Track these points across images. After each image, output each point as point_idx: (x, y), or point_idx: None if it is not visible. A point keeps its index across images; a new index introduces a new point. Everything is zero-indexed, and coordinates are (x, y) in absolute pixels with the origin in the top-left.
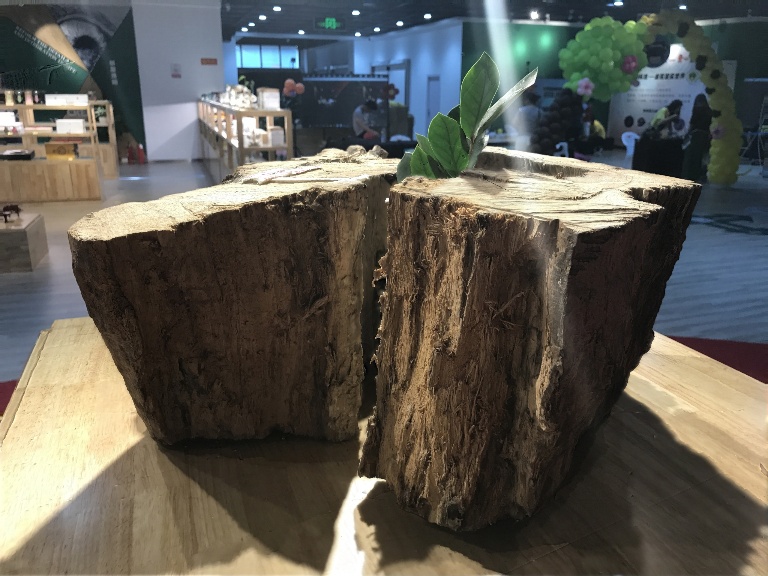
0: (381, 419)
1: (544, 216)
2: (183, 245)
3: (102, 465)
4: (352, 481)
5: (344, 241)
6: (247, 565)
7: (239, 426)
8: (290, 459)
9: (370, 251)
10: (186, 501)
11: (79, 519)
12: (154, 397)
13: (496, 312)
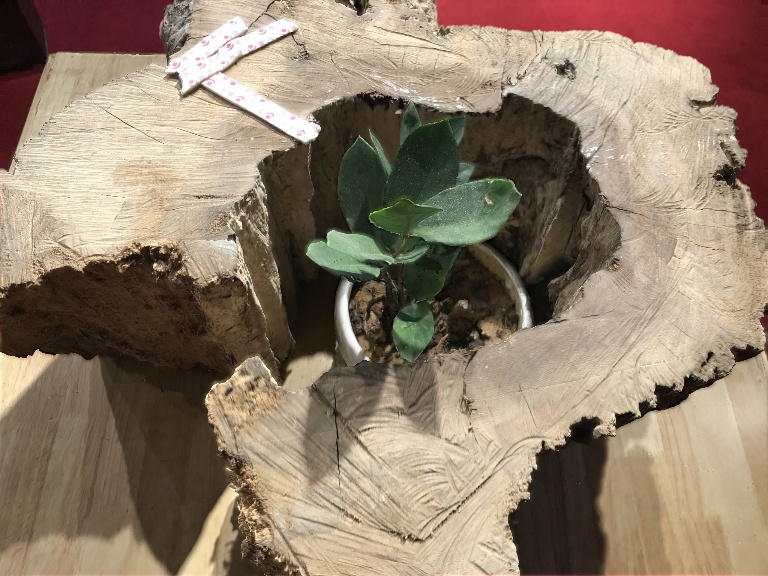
0: None
1: None
2: (25, 296)
3: (45, 361)
4: None
5: (218, 315)
6: (121, 546)
7: (160, 365)
8: None
9: None
10: (97, 444)
11: (12, 436)
12: (65, 348)
13: (292, 575)
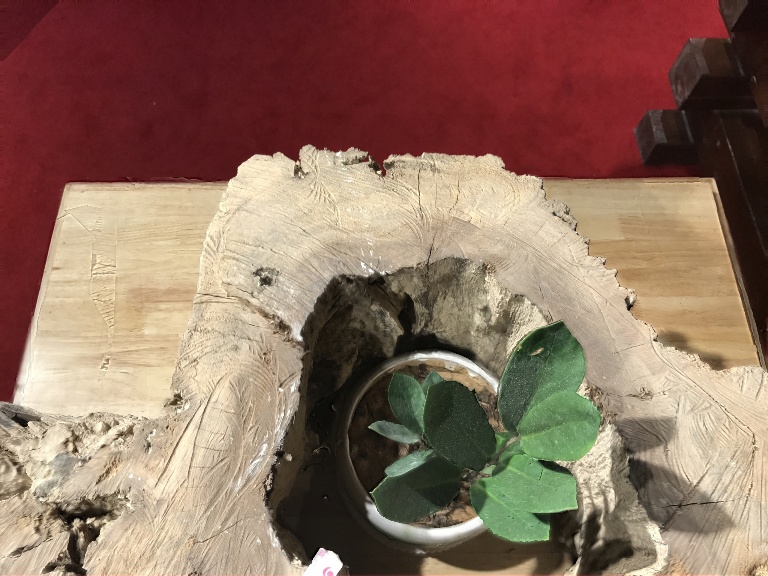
0: None
1: None
2: None
3: None
4: None
5: None
6: None
7: None
8: None
9: (290, 538)
10: None
11: None
12: None
13: None
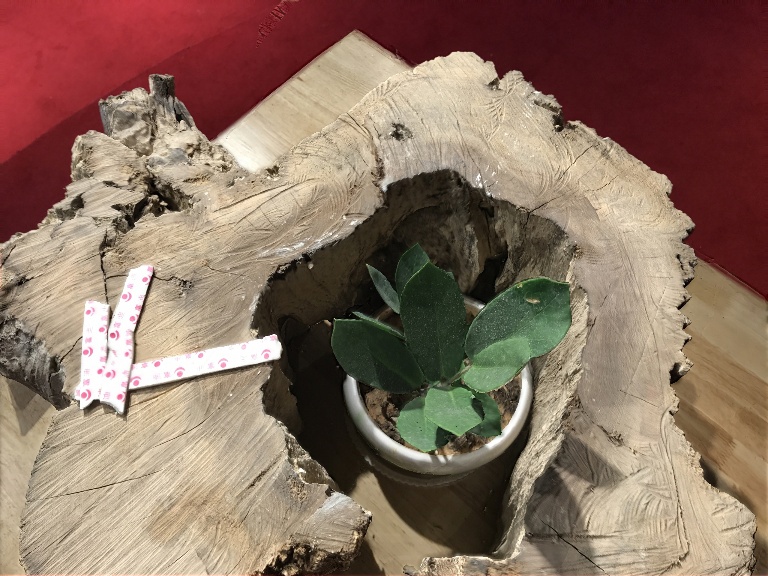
0: None
1: None
2: None
3: None
4: None
5: None
6: None
7: None
8: None
9: None
10: None
11: None
12: None
13: None
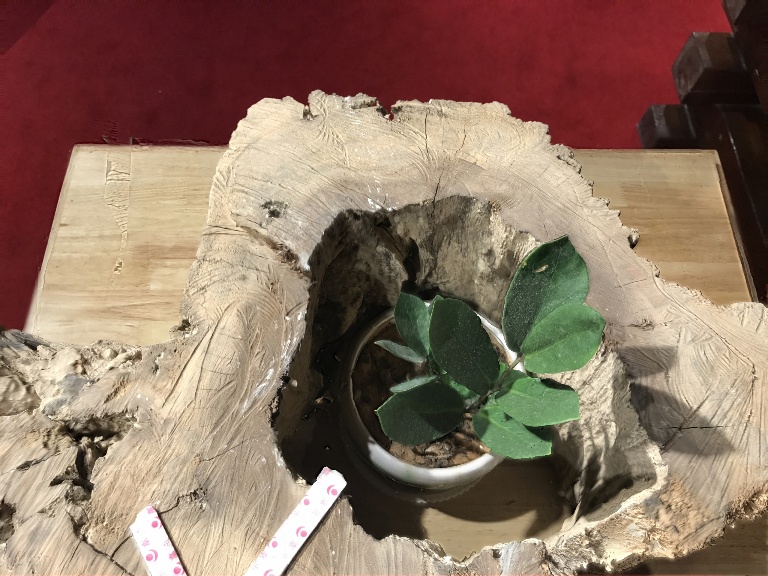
0: None
1: None
2: None
3: None
4: None
5: None
6: None
7: None
8: None
9: None
10: None
11: None
12: None
13: None
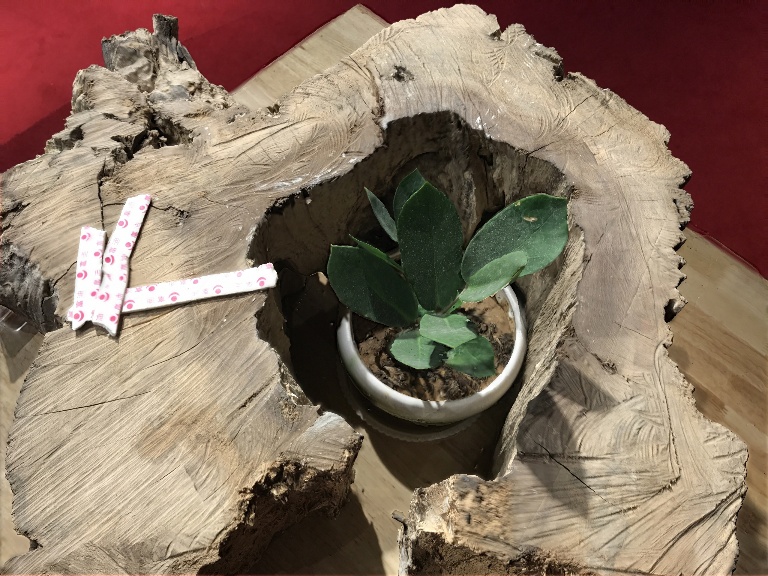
0: (421, 561)
1: (666, 573)
2: None
3: None
4: (383, 563)
5: None
6: None
7: None
8: (309, 560)
9: None
10: None
11: None
12: None
13: None
